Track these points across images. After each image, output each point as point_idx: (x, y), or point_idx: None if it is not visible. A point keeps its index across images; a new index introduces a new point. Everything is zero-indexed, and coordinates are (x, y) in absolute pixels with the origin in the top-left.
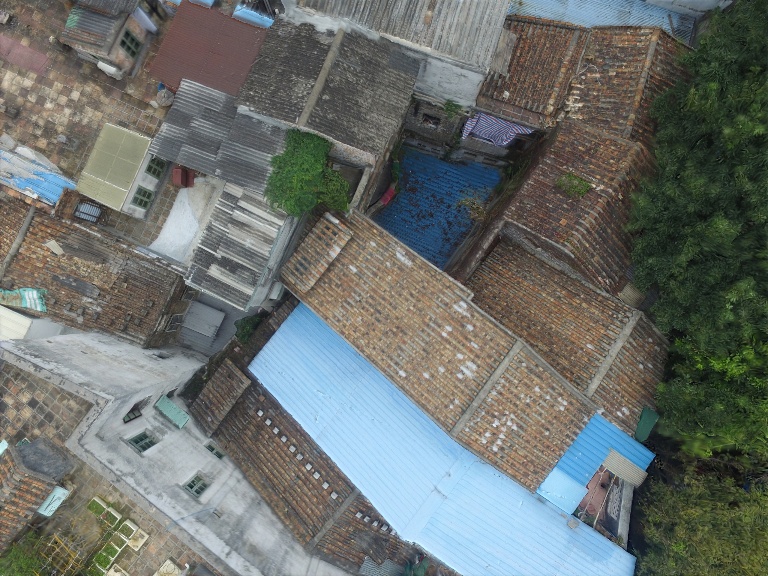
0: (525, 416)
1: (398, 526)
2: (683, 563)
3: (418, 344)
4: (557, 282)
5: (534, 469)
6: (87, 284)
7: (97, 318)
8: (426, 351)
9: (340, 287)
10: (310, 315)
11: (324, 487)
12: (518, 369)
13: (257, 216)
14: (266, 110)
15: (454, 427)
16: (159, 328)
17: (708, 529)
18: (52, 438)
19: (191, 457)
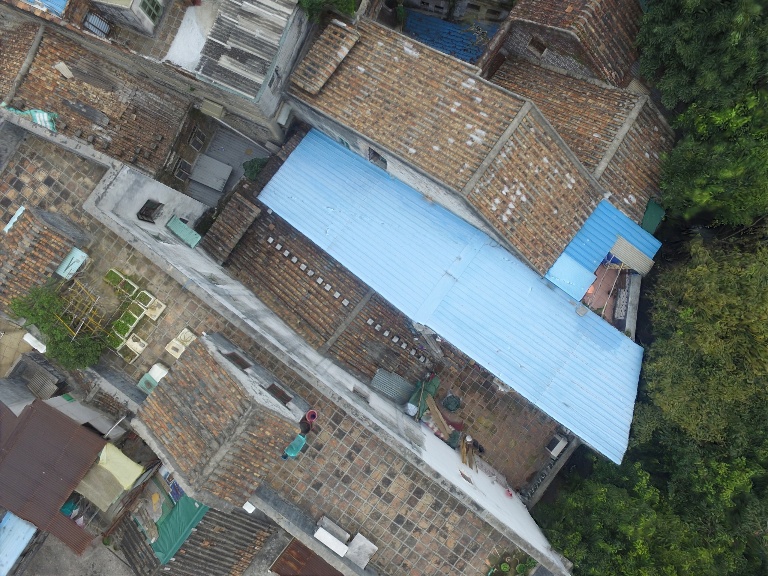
0: (534, 188)
1: (410, 311)
2: (690, 334)
3: (427, 123)
4: (563, 86)
5: (543, 250)
6: (97, 112)
7: (107, 147)
8: (435, 128)
9: (349, 87)
10: (318, 142)
11: (335, 296)
12: (527, 134)
13: (266, 6)
14: None
15: (465, 186)
16: (168, 164)
17: (715, 289)
18: (68, 214)
19: (204, 265)
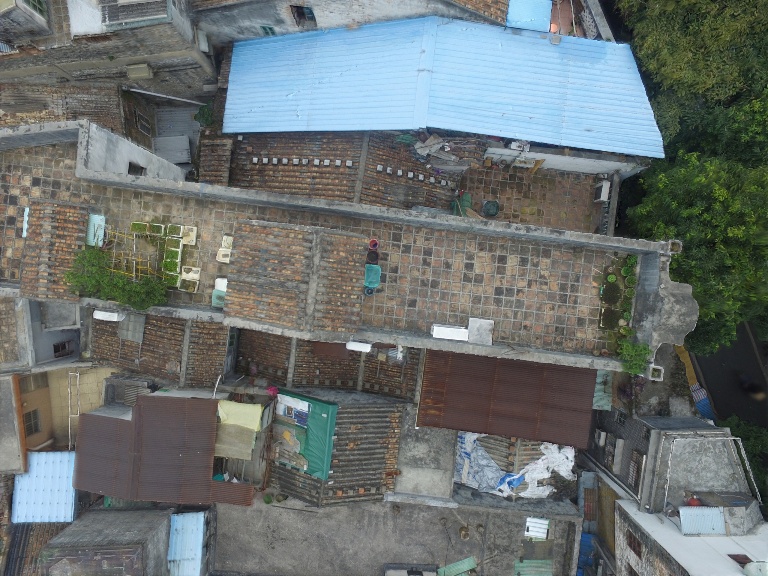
0: None
1: (407, 124)
2: None
3: None
4: None
5: (491, 0)
6: None
7: None
8: None
9: None
10: (246, 51)
11: (338, 165)
12: None
13: None
14: None
15: None
16: None
17: None
18: (69, 200)
19: None
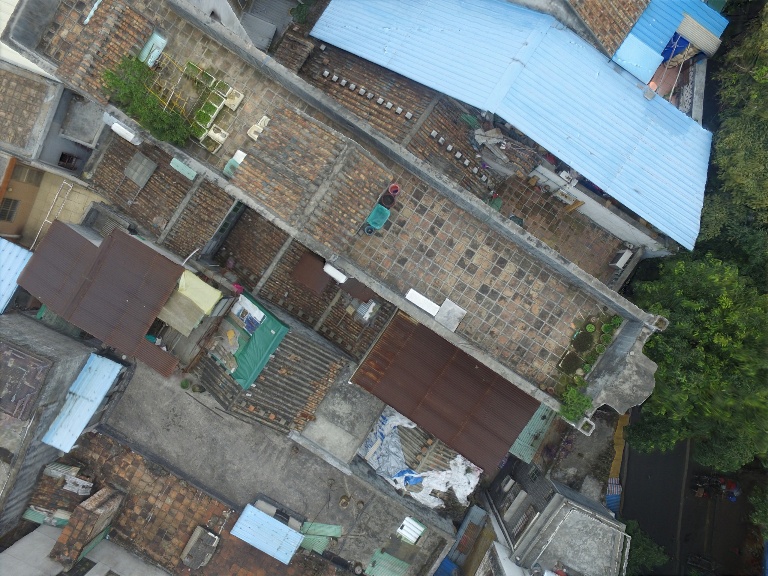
0: None
1: (479, 102)
2: (764, 99)
3: None
4: None
5: (610, 28)
6: None
7: None
8: None
9: None
10: None
11: (398, 112)
12: None
13: None
14: None
15: None
16: None
17: None
18: None
19: None
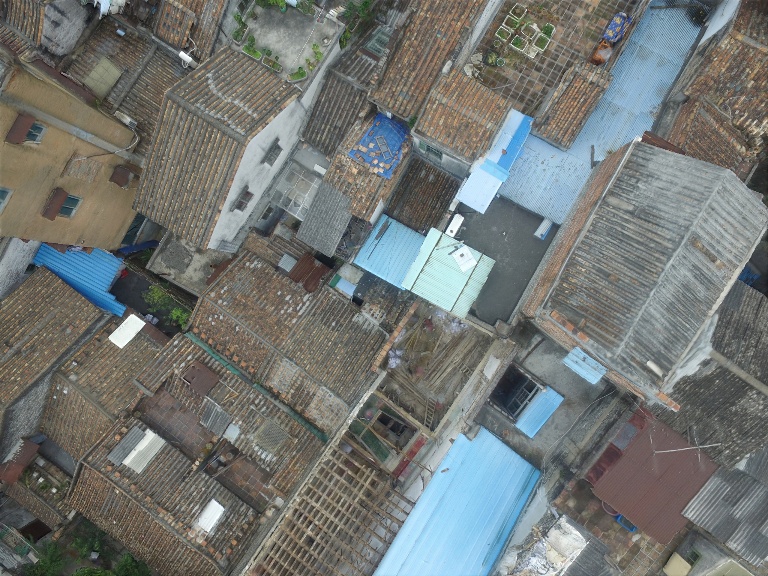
0: None
1: None
2: None
3: None
4: None
5: None
6: None
7: None
8: None
9: None
10: None
11: None
12: None
13: None
14: (760, 443)
15: None
16: None
17: None
18: None
19: None
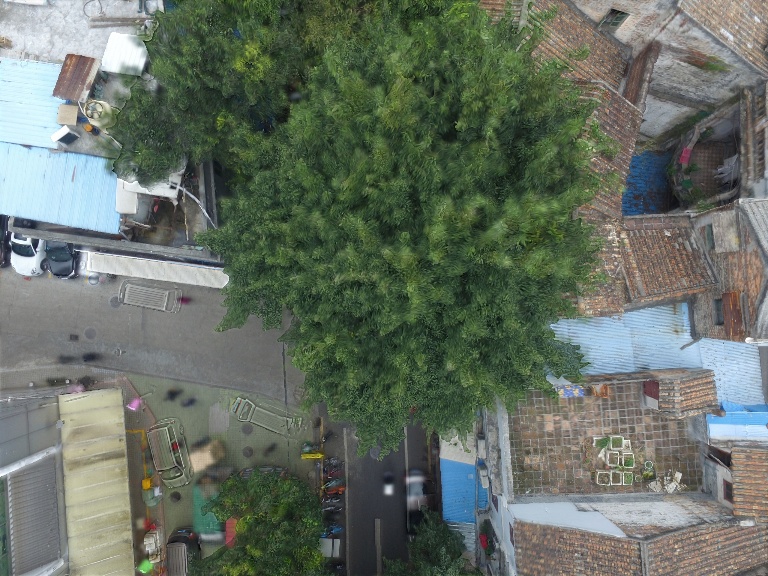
0: None
1: None
2: None
3: None
4: None
5: None
6: None
7: None
8: None
9: (761, 1)
10: None
11: None
12: None
13: None
14: None
15: None
16: None
17: None
18: None
19: None
